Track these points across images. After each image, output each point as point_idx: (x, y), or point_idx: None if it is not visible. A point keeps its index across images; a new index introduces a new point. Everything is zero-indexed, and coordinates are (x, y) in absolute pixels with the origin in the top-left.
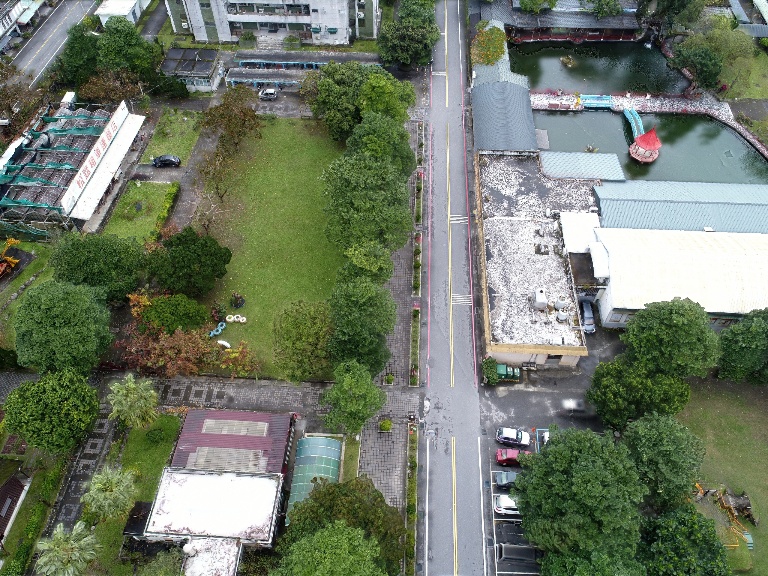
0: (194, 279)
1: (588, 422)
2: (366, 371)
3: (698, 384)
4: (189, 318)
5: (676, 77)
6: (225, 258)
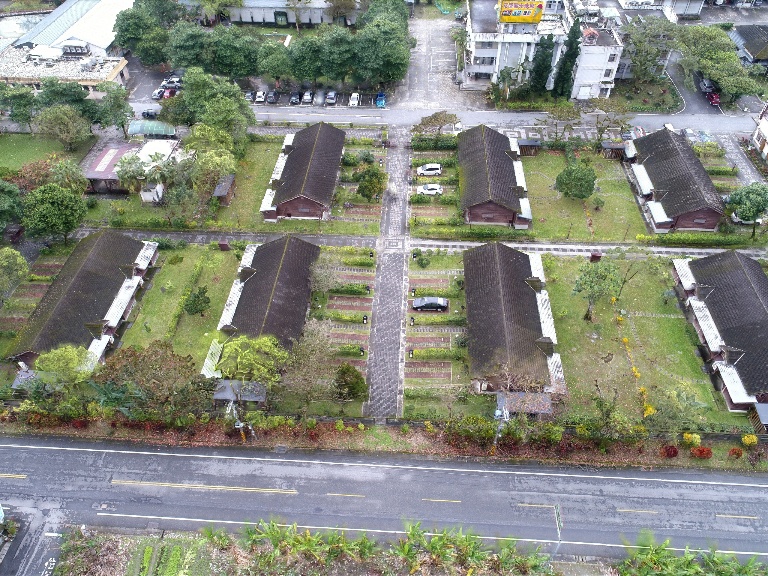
0: None
1: (162, 77)
2: None
3: None
4: None
5: None
6: None
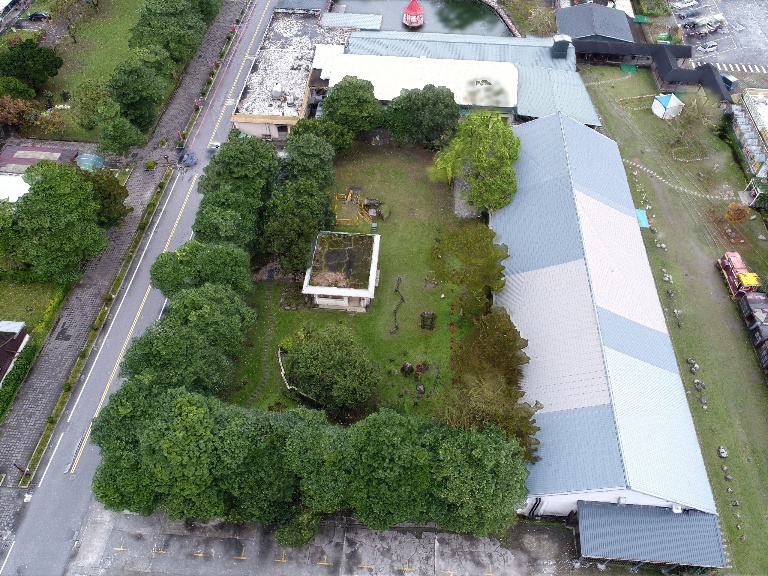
0: (28, 71)
1: None
2: (117, 105)
3: (384, 151)
4: (19, 93)
5: None
6: (56, 63)
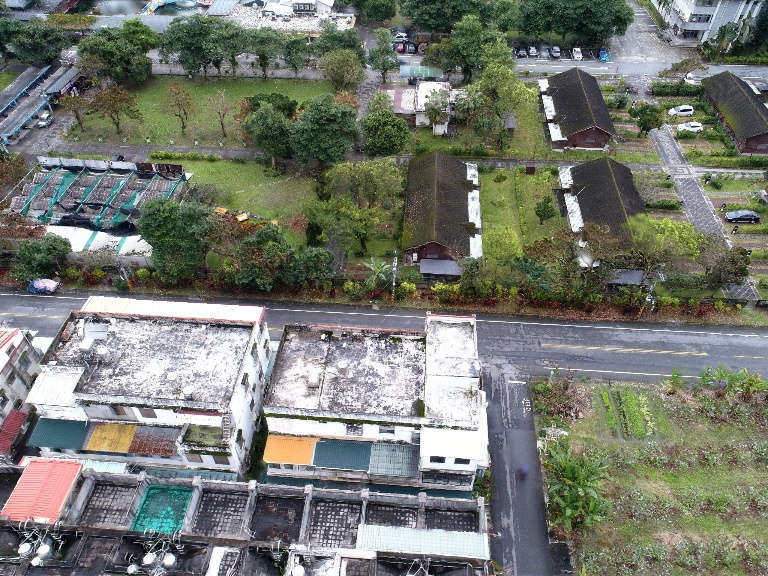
0: None
1: None
2: None
3: None
4: None
5: None
6: None
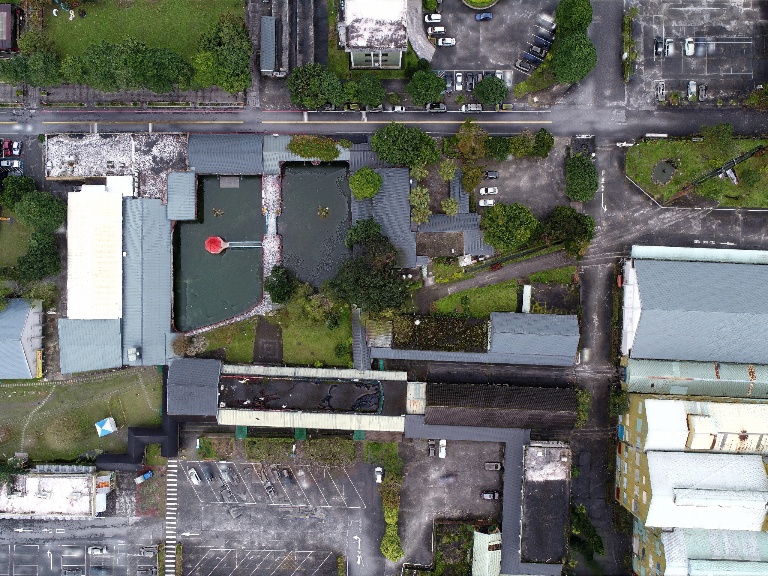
0: None
1: None
2: None
3: None
4: None
5: (315, 292)
6: None
